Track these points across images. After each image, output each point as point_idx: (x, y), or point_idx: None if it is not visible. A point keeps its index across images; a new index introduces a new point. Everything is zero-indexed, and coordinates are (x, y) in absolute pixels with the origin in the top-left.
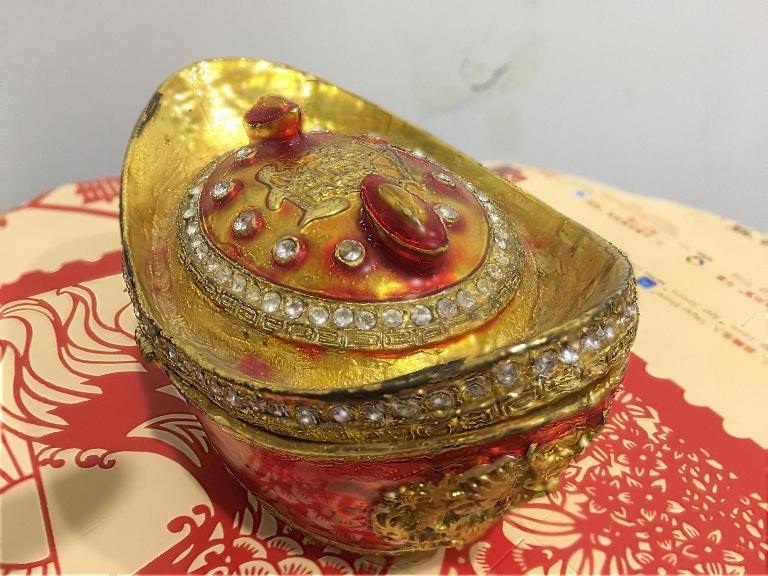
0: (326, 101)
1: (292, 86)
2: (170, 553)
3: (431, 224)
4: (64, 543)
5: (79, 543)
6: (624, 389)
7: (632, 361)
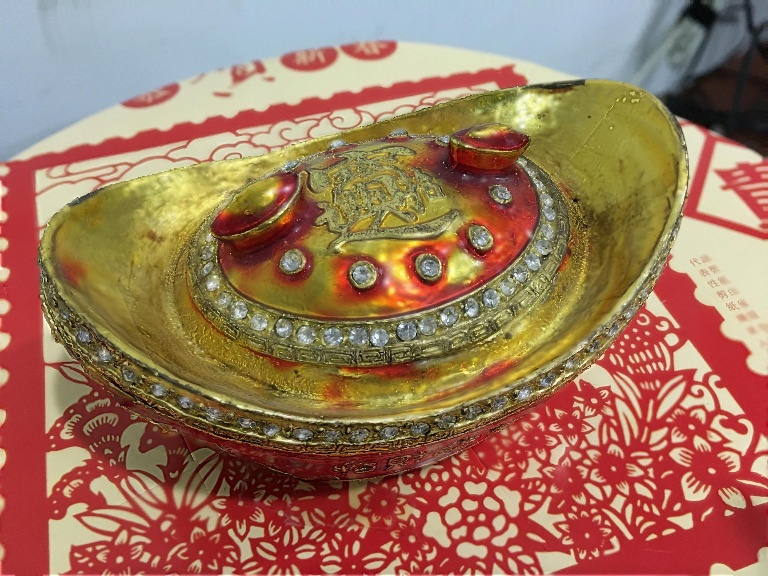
0: (646, 228)
1: (659, 188)
2: None
3: (235, 221)
4: None
5: None
6: None
7: None
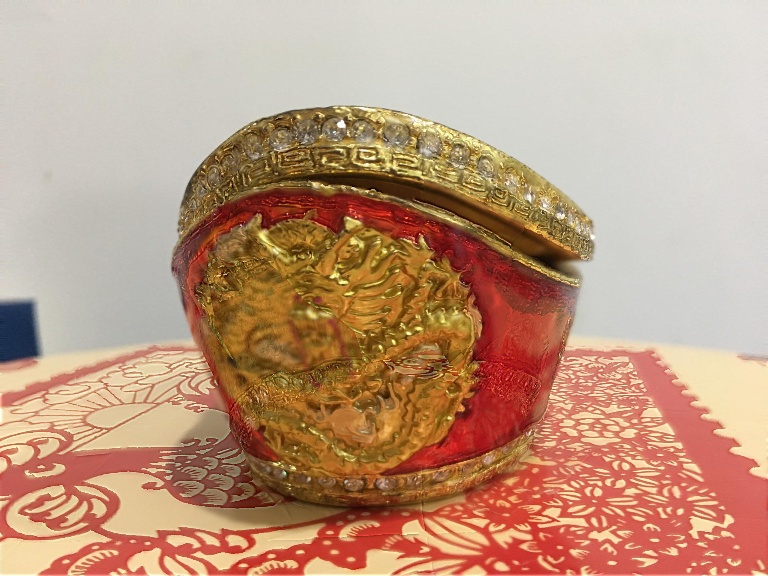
0: None
1: None
2: (164, 448)
3: None
4: (125, 427)
5: (131, 430)
6: (713, 497)
7: (761, 486)
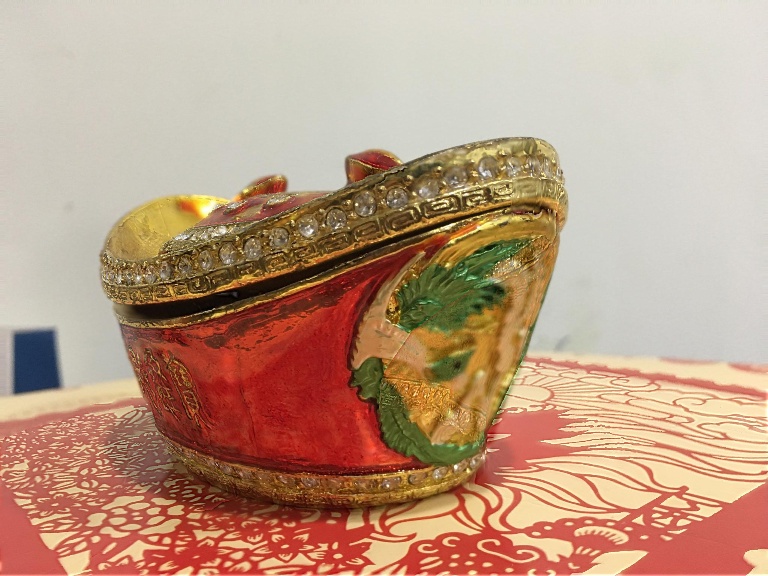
0: None
1: None
2: None
3: None
4: None
5: None
6: (8, 484)
7: None
